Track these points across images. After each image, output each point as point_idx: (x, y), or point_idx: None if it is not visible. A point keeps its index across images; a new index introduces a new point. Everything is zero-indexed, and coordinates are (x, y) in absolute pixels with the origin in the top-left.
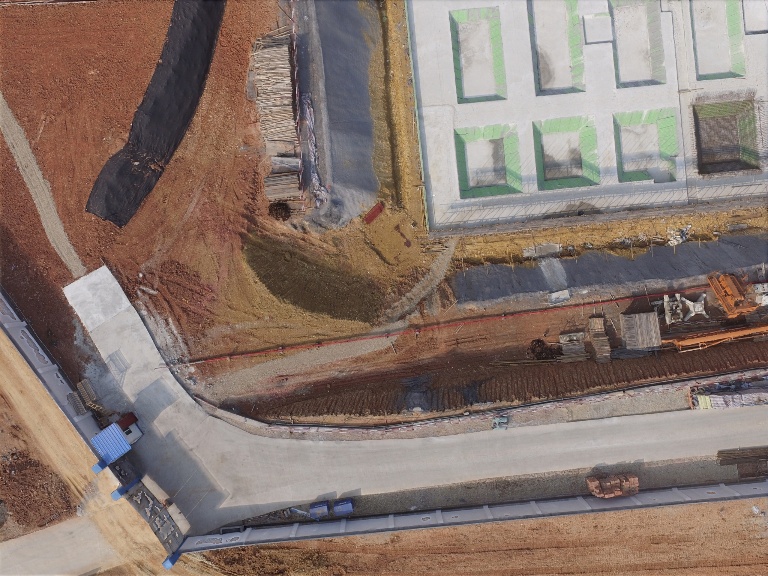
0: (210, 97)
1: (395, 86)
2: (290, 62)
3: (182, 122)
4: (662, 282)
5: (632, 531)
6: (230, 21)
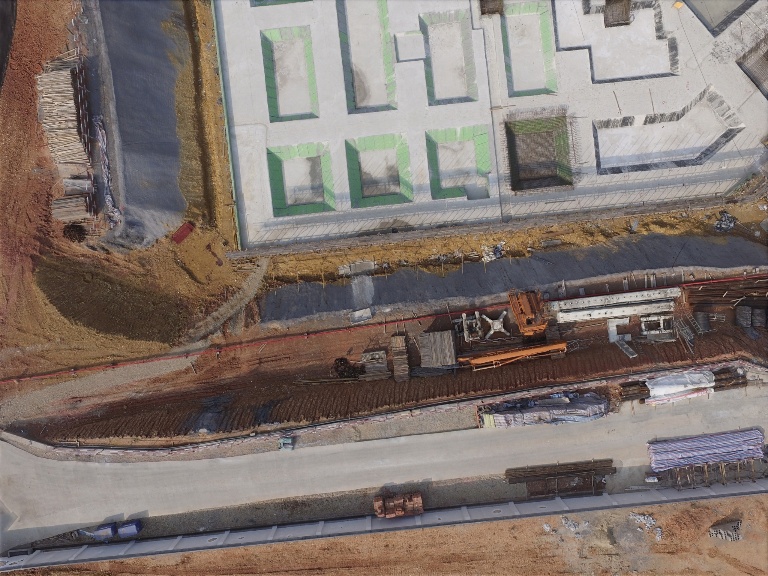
0: (2, 120)
1: (207, 105)
2: (74, 85)
3: None
4: (464, 300)
5: (423, 550)
6: (20, 44)
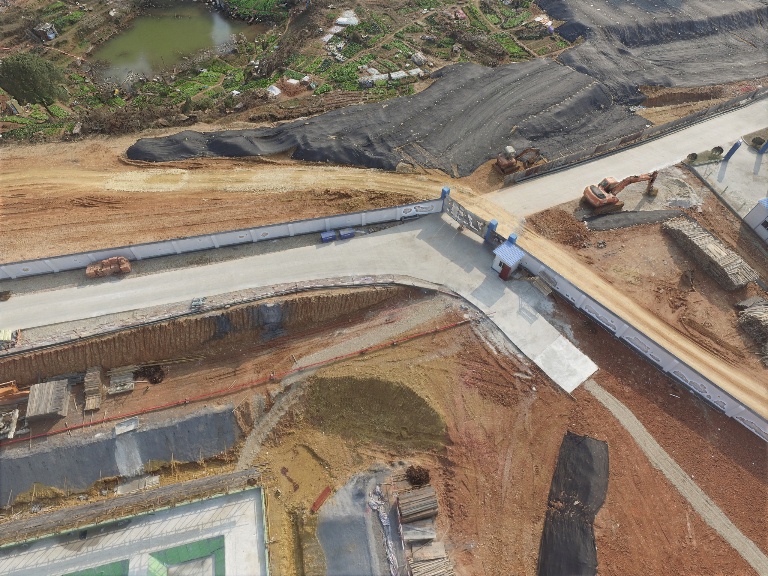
0: None
1: None
2: None
3: (546, 567)
4: (10, 455)
5: (101, 243)
6: None
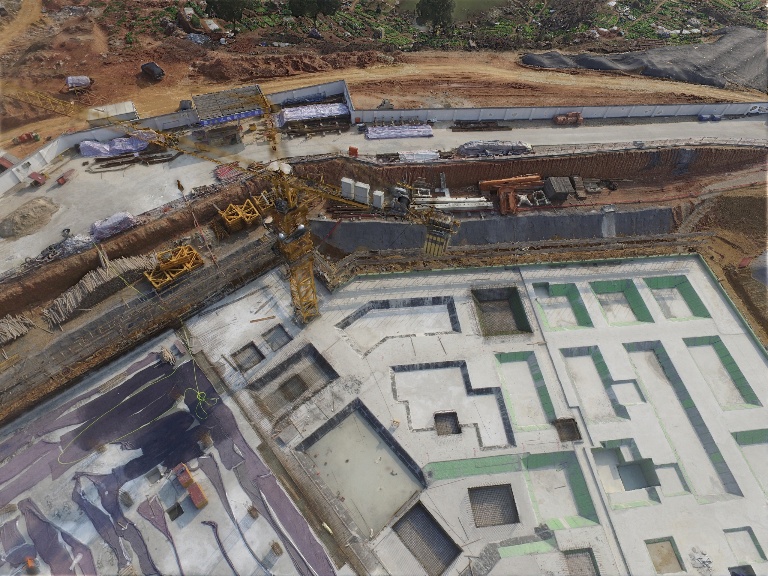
0: None
1: None
2: None
3: None
4: (545, 214)
5: None
6: None
